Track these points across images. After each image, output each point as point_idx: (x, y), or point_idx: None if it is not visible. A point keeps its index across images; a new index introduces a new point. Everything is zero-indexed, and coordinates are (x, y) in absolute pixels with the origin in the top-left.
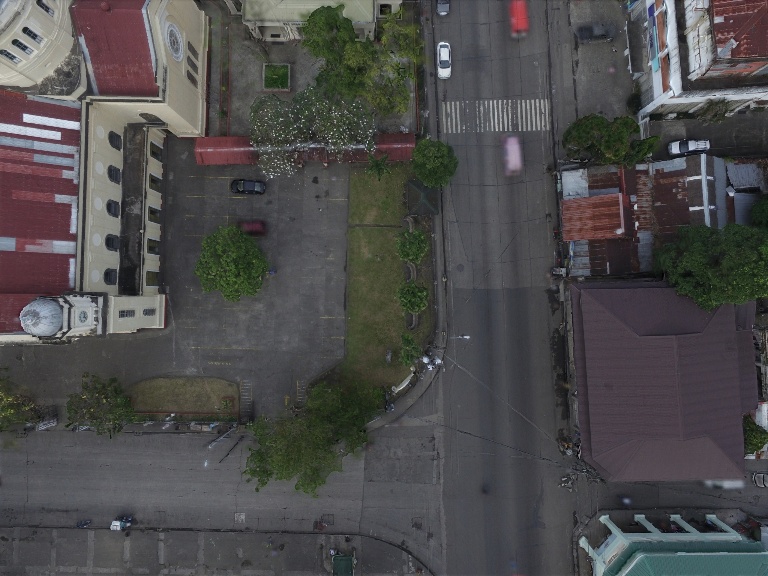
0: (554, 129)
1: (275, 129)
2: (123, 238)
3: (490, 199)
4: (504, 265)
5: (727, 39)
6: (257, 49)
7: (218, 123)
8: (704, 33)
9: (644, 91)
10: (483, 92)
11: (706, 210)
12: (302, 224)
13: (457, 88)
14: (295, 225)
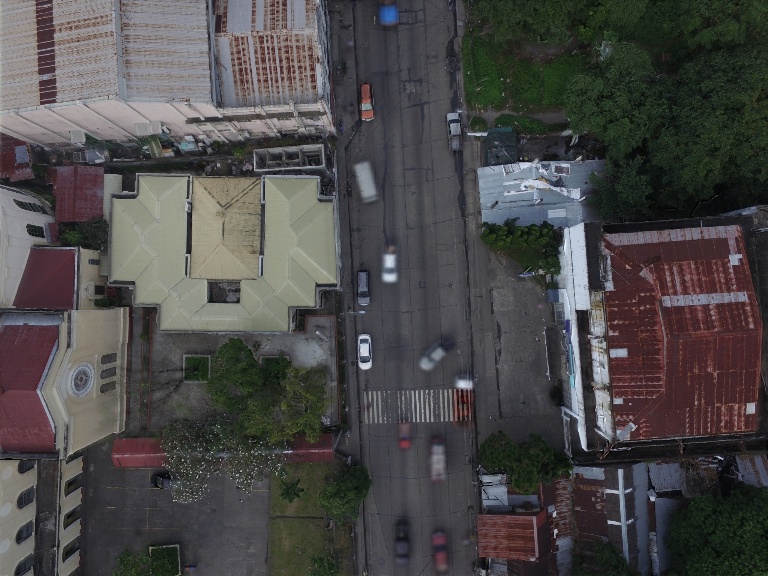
0: (476, 419)
1: (183, 465)
2: (37, 554)
3: (411, 492)
4: (425, 559)
5: (626, 422)
6: (164, 386)
7: (139, 414)
8: (606, 403)
9: (565, 390)
10: (405, 382)
11: (623, 527)
12: (223, 515)
13: (379, 377)
14: (216, 516)
